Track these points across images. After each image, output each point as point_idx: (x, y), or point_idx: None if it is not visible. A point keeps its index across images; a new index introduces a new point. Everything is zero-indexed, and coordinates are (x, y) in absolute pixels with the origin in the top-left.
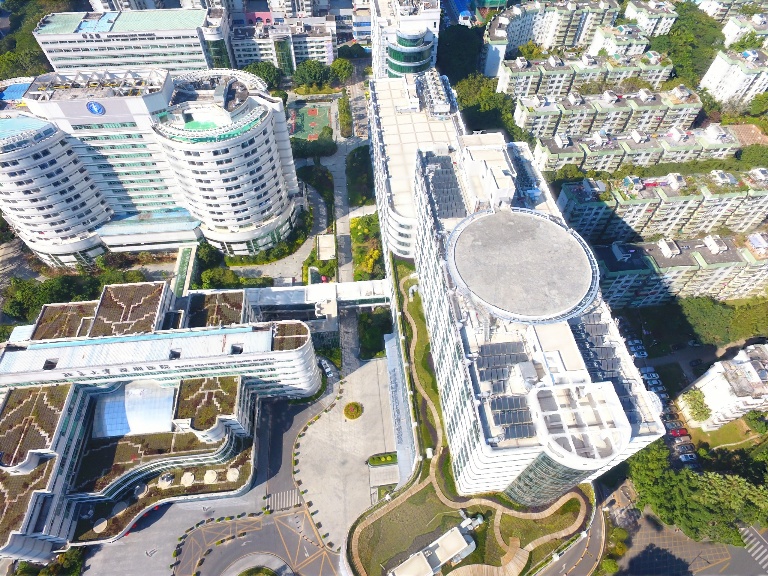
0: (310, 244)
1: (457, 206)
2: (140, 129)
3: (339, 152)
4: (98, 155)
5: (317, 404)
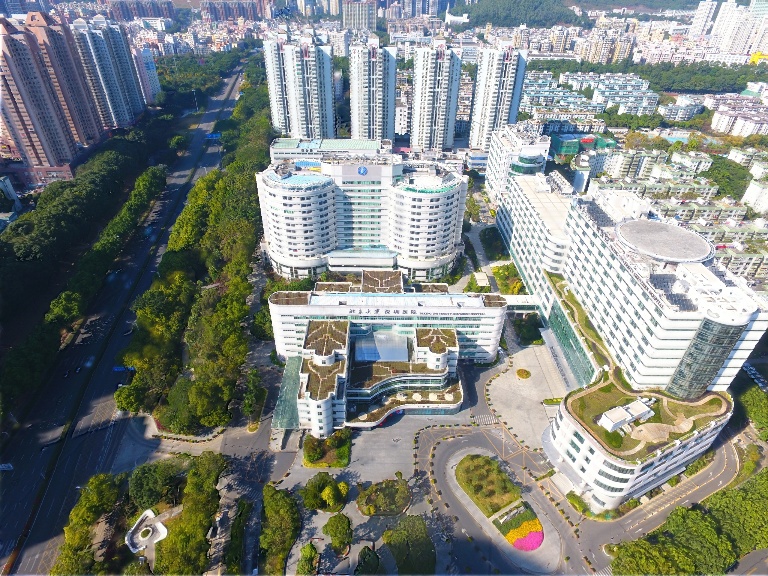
0: (465, 280)
1: None
2: (382, 186)
3: (473, 230)
4: (348, 202)
5: (495, 368)
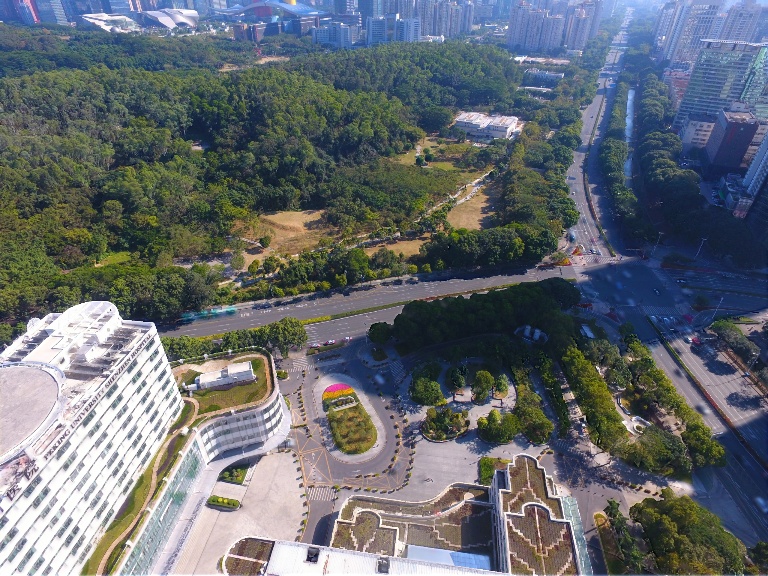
0: None
1: None
2: None
3: None
4: None
5: None
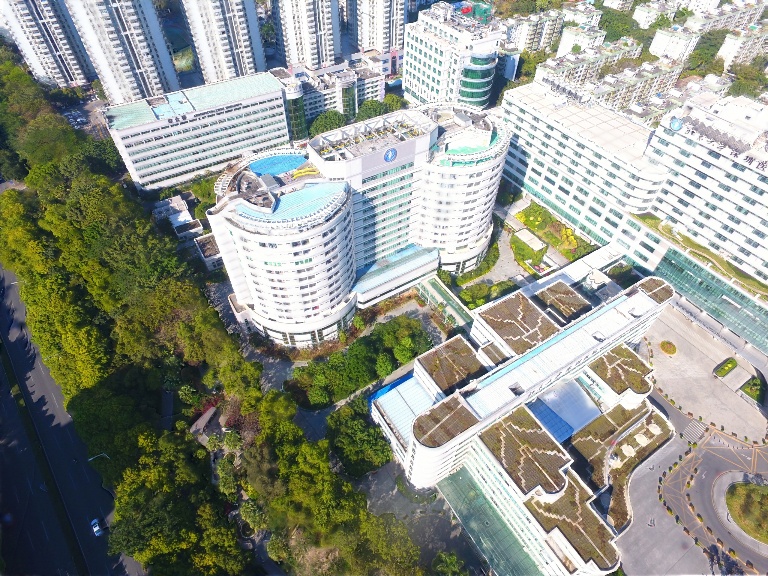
0: (504, 245)
1: (740, 143)
2: (414, 168)
3: None
4: (369, 207)
5: (640, 355)
